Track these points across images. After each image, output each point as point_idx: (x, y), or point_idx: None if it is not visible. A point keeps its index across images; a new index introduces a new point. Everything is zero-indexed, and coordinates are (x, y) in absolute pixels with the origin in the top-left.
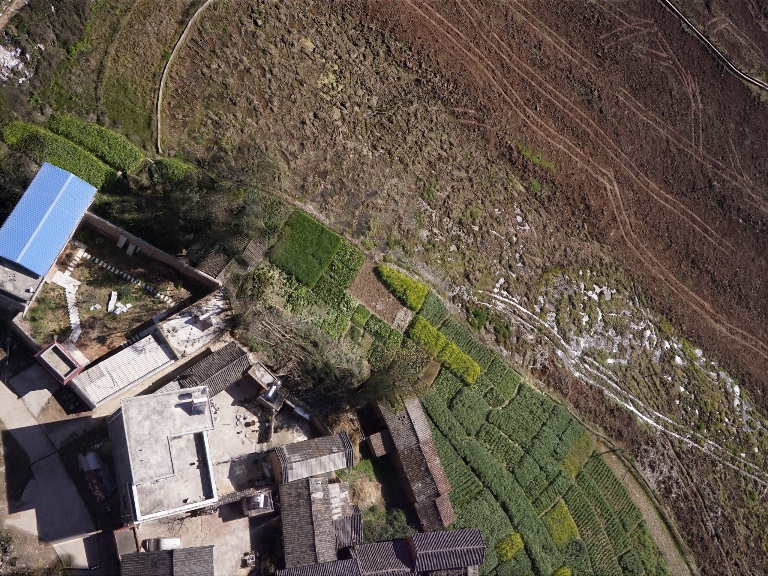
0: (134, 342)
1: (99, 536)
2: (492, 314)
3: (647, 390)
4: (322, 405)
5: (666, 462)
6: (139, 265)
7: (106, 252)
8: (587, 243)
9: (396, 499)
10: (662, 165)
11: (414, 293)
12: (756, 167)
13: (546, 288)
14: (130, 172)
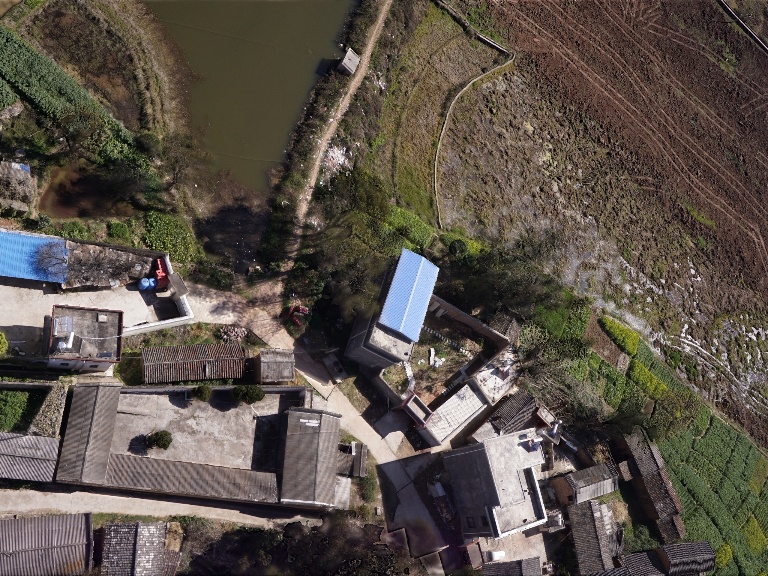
0: (451, 390)
1: (448, 550)
2: (684, 356)
3: None
4: (581, 439)
5: None
6: (445, 325)
7: None
8: (743, 290)
9: (638, 516)
10: None
11: (630, 341)
12: None
13: (718, 331)
14: (425, 246)
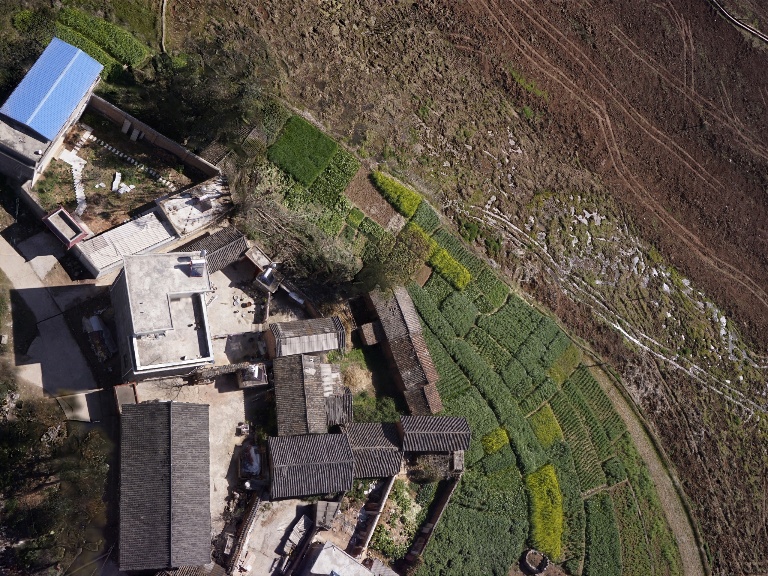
0: None
1: (101, 393)
2: (483, 228)
3: (634, 312)
4: (316, 294)
5: (651, 380)
6: (142, 151)
7: (111, 136)
8: (578, 170)
9: (386, 388)
10: (654, 102)
11: (407, 200)
12: (747, 110)
13: (537, 209)
14: (135, 66)
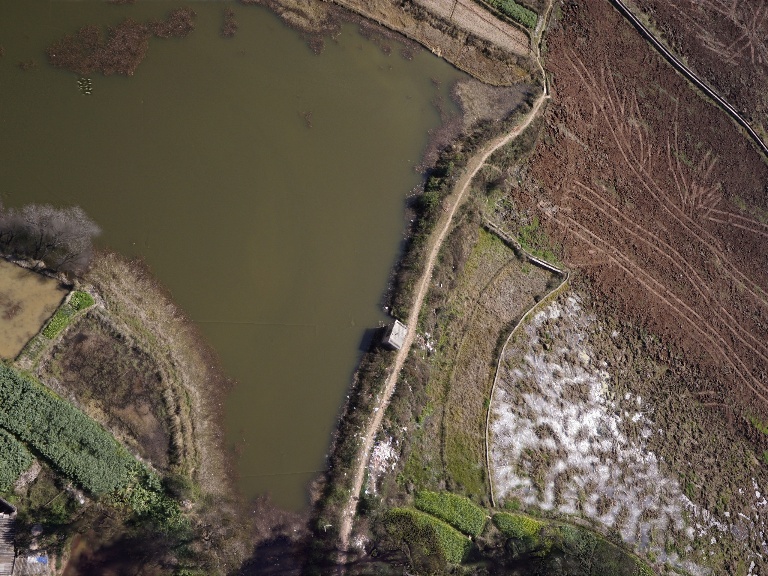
0: None
1: None
2: None
3: None
4: None
5: None
6: None
7: None
8: None
9: None
10: None
11: None
12: None
13: None
14: None
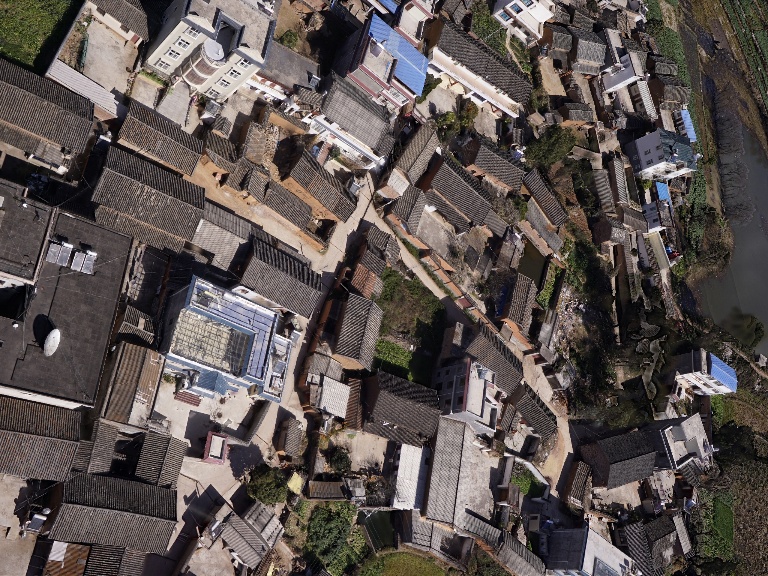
0: None
1: None
2: None
3: None
4: None
5: None
6: None
7: (695, 410)
8: None
9: None
10: None
11: None
12: None
13: None
14: (714, 418)
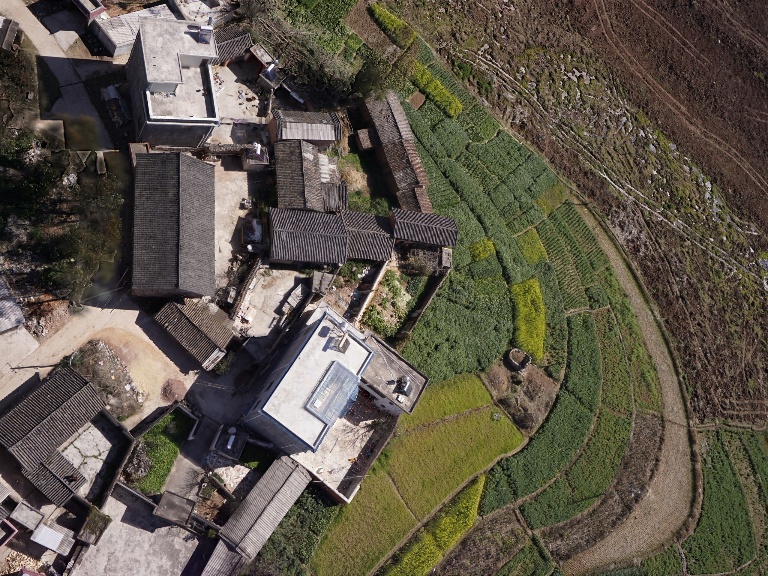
0: None
1: (117, 154)
2: (476, 69)
3: (621, 165)
4: (316, 99)
5: (636, 226)
6: None
7: None
8: (569, 33)
9: (380, 191)
10: None
11: (403, 33)
12: None
13: (528, 62)
14: None
